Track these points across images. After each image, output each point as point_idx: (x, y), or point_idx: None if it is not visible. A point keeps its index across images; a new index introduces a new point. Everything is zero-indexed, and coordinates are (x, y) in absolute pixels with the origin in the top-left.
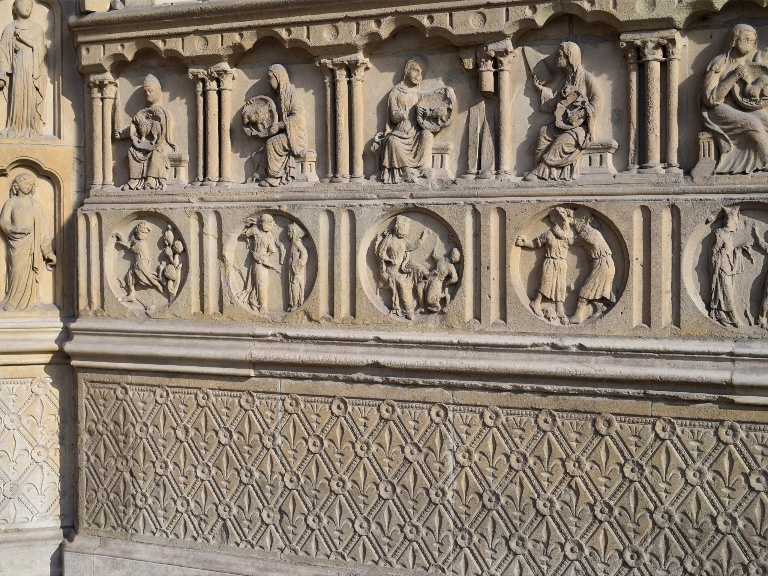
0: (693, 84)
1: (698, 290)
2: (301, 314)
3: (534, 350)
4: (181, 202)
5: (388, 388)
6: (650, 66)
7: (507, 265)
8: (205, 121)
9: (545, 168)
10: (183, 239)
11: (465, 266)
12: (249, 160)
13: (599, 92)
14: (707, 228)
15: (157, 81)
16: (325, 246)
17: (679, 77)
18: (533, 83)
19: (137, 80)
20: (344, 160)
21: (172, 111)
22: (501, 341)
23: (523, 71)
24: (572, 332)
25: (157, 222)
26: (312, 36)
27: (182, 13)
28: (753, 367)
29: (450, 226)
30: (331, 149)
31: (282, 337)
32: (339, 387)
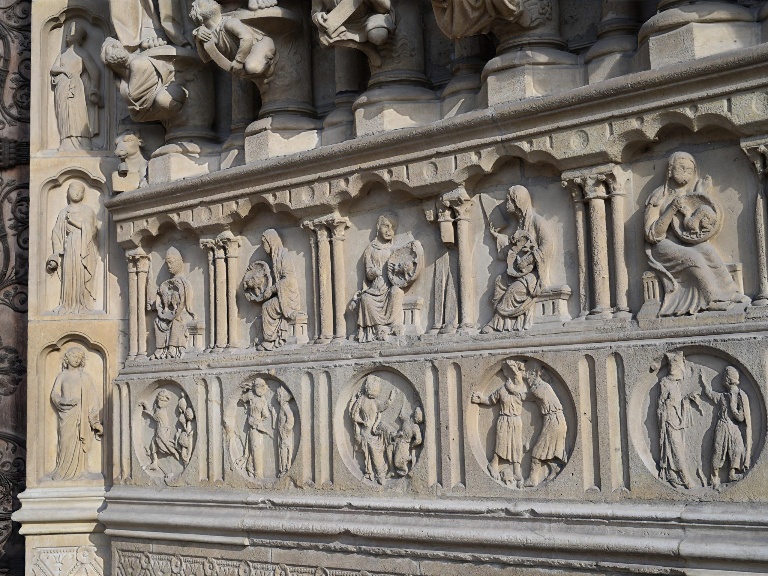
0: (639, 220)
1: (648, 447)
2: (288, 480)
3: (490, 516)
4: (192, 369)
5: (362, 558)
6: (592, 204)
7: (464, 424)
8: (215, 289)
9: (499, 319)
10: (192, 406)
11: (426, 426)
12: (253, 325)
13: (547, 235)
14: (653, 377)
15: (178, 253)
16: (307, 409)
17: (624, 214)
18: (489, 231)
19: (165, 253)
20: (327, 321)
21: (191, 281)
22: (458, 507)
23: (481, 219)
24: (526, 496)
25: (174, 390)
26: (293, 199)
27: (188, 187)
28: (704, 535)
29: (412, 384)
30: (317, 310)
31: (271, 504)
32: (320, 557)
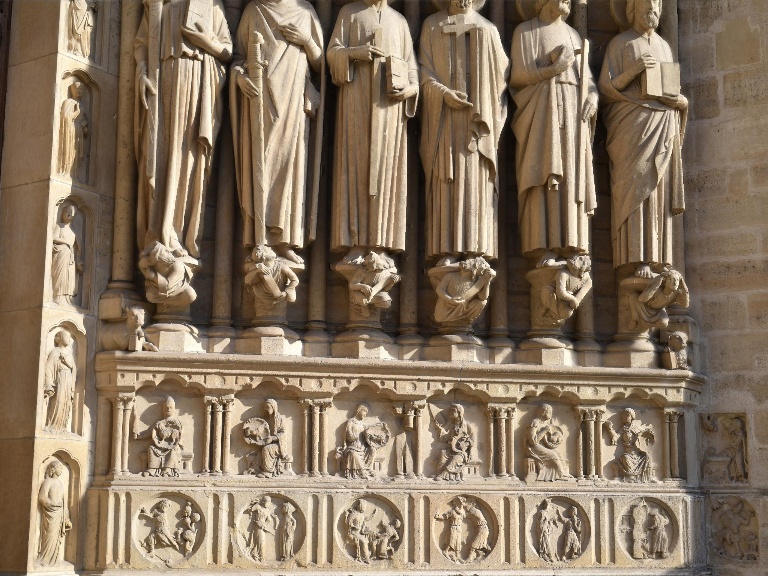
0: (520, 432)
1: (532, 543)
2: (293, 562)
3: None
4: (198, 486)
5: None
6: (502, 421)
7: (430, 530)
8: (213, 431)
9: (447, 474)
10: (202, 512)
11: (405, 530)
12: (242, 459)
13: (474, 433)
14: (536, 509)
15: (174, 401)
16: (310, 518)
17: None
18: (436, 425)
19: (153, 399)
20: None
21: (182, 422)
22: (430, 575)
23: (428, 417)
24: (468, 568)
25: (176, 500)
26: (304, 385)
27: (212, 360)
28: None
29: (396, 506)
30: (307, 455)
31: None
32: None
